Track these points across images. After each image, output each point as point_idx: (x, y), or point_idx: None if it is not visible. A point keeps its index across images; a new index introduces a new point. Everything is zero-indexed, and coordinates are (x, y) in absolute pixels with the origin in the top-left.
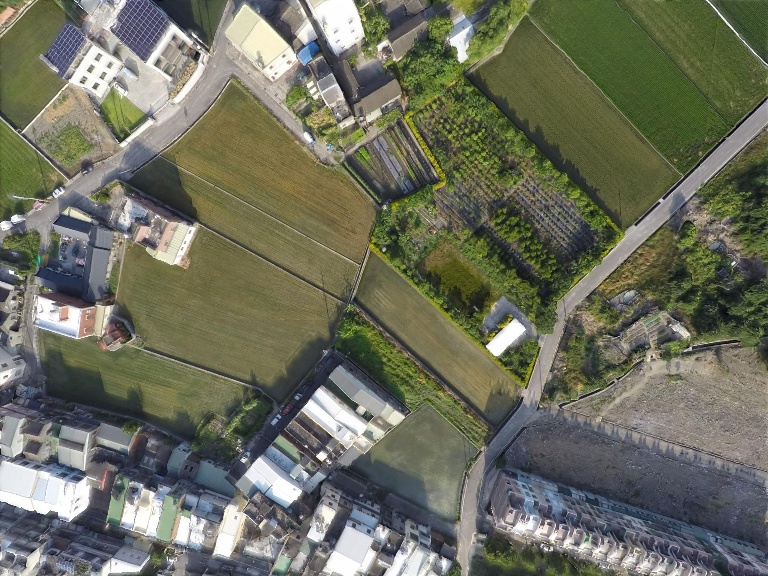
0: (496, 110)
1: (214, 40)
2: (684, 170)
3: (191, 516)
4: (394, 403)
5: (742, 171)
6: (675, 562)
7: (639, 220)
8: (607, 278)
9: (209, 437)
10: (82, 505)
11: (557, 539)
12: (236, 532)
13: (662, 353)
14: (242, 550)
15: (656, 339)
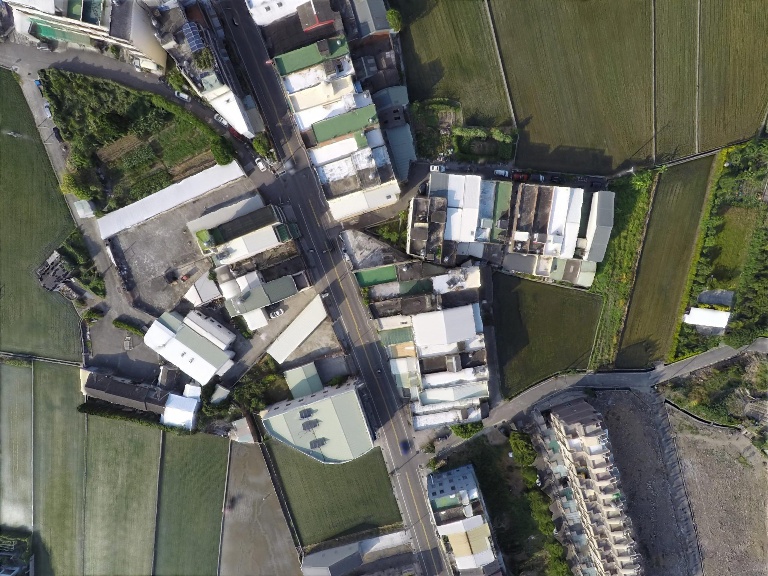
0: None
1: None
2: None
3: (367, 147)
4: None
5: None
6: (639, 565)
7: None
8: None
9: (431, 117)
10: (267, 16)
11: (597, 475)
12: None
13: (758, 437)
14: (329, 232)
15: (764, 425)
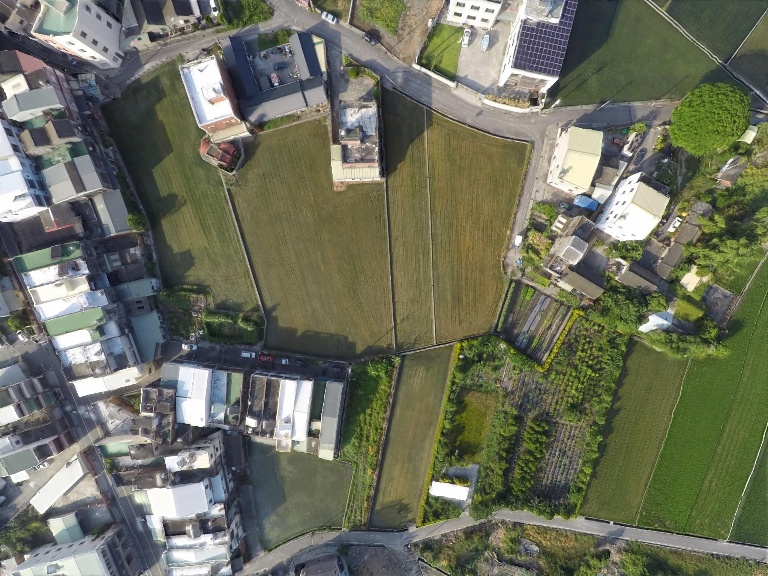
0: (617, 376)
1: (554, 108)
2: (640, 523)
3: (97, 342)
4: (337, 442)
5: (658, 557)
6: None
7: (590, 518)
8: (537, 525)
9: (183, 301)
10: (10, 218)
11: None
12: (112, 389)
13: None
14: (90, 396)
15: None
